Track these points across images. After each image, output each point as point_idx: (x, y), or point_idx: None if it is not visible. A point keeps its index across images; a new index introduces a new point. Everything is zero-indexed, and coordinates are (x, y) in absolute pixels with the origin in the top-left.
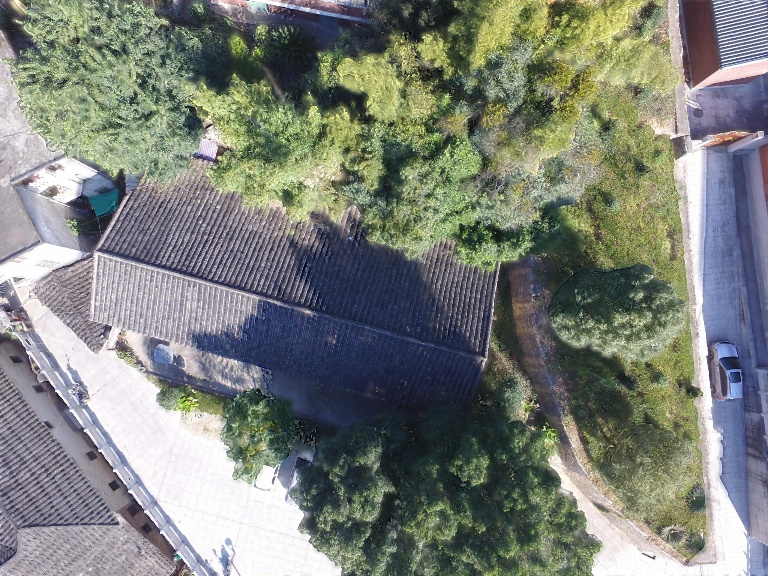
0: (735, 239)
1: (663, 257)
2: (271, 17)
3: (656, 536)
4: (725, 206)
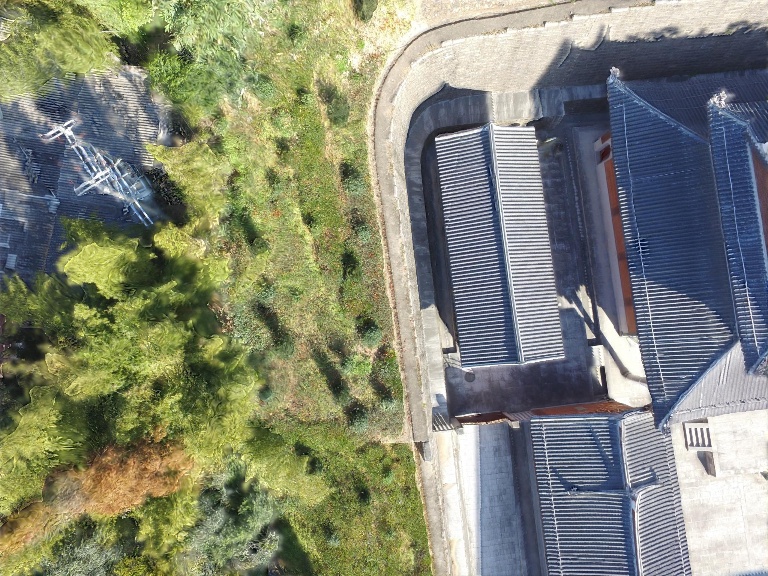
0: (514, 508)
1: None
2: None
3: None
4: (501, 475)
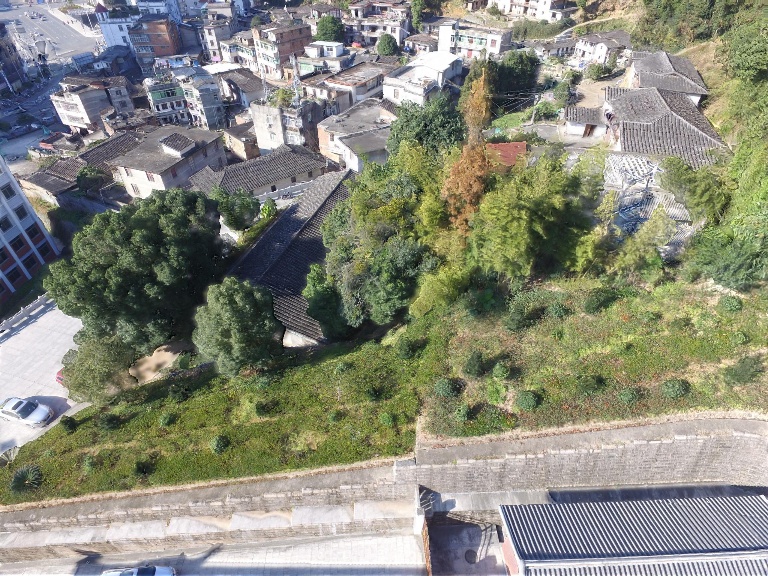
0: None
1: (287, 427)
2: None
3: None
4: None
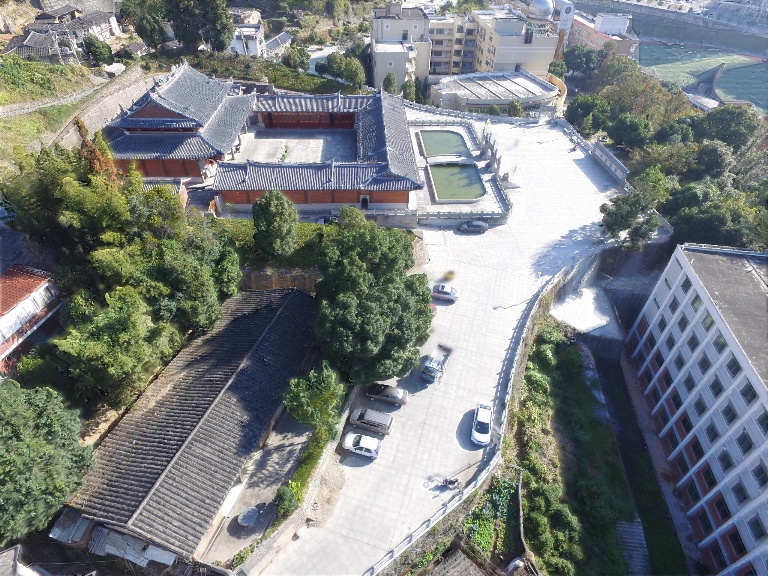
0: None
1: None
2: (10, 372)
3: None
4: (248, 217)
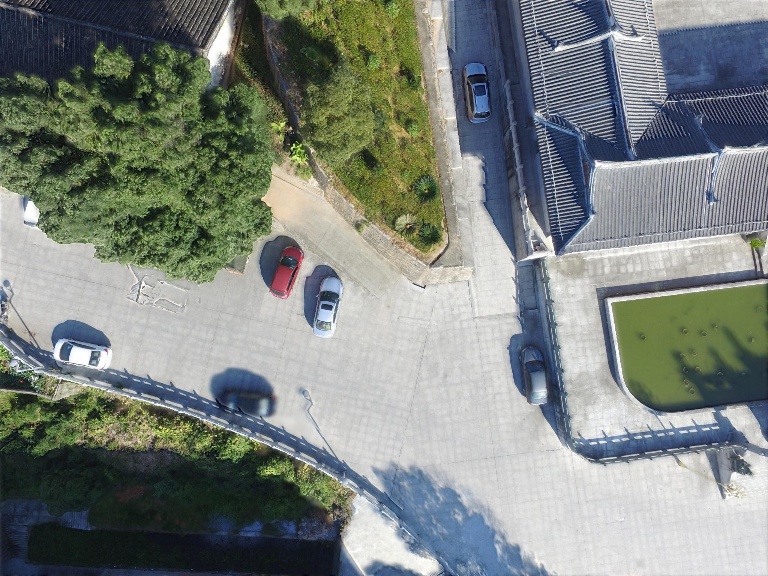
0: None
1: None
2: None
3: (399, 238)
4: None
